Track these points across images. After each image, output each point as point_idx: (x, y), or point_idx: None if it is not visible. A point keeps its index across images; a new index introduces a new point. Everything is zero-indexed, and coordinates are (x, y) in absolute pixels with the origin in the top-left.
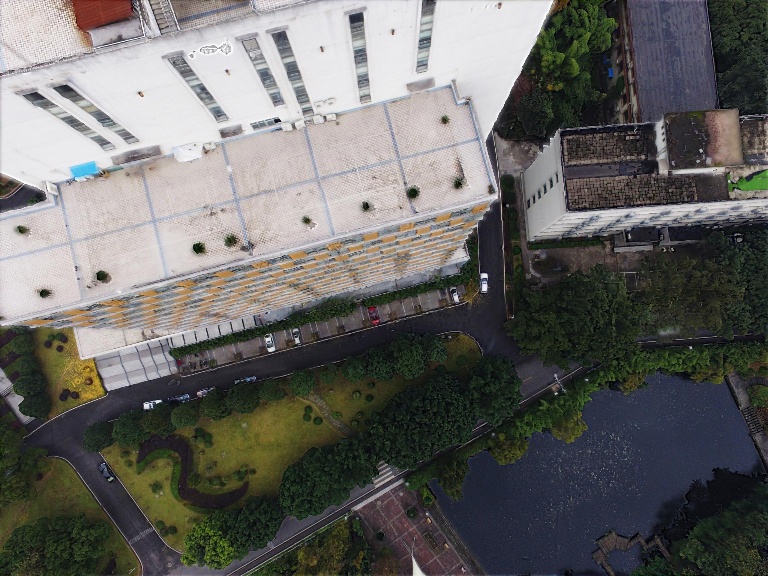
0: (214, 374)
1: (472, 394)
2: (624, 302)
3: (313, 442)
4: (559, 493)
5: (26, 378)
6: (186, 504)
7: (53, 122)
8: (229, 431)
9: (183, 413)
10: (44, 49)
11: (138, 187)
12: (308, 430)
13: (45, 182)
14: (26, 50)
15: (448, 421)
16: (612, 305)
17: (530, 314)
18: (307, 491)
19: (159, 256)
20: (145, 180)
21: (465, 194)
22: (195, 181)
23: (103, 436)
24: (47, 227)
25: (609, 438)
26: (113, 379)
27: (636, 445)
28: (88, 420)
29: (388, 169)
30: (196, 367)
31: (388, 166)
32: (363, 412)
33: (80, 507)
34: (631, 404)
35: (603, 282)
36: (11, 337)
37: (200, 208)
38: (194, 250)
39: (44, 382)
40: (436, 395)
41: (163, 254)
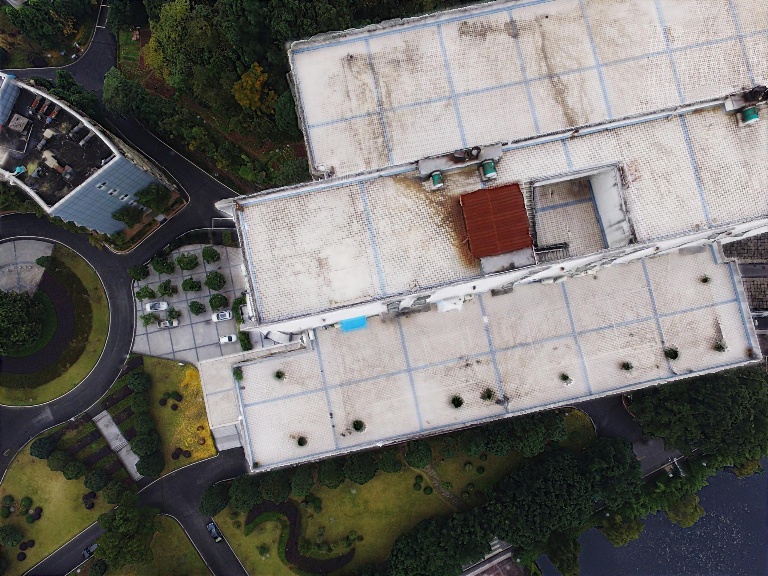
0: None
1: (594, 477)
2: (764, 399)
3: (422, 511)
4: (666, 574)
5: (144, 438)
6: (292, 568)
7: (377, 307)
8: (338, 497)
9: (304, 484)
10: (422, 265)
11: (394, 335)
12: (417, 499)
13: (307, 330)
14: (404, 266)
15: (570, 504)
16: (750, 401)
17: (658, 400)
18: (421, 565)
19: (414, 406)
20: (401, 328)
21: (724, 356)
22: (451, 331)
23: (221, 501)
24: (303, 372)
25: (718, 520)
26: (225, 439)
27: (746, 529)
28: (198, 479)
29: (646, 327)
30: None
31: (646, 324)
32: (473, 484)
33: (187, 566)
34: (742, 487)
35: (742, 377)
36: (127, 393)
37: (456, 359)
38: (454, 404)
39: (159, 441)
40: (558, 476)
41: (418, 404)
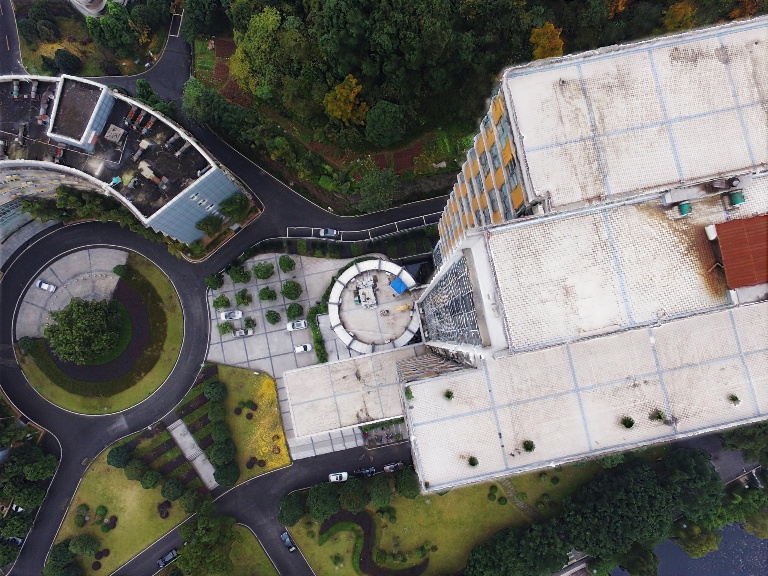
0: (399, 448)
1: (675, 489)
2: None
3: (496, 522)
4: None
5: (222, 447)
6: None
7: None
8: (413, 507)
9: (386, 494)
10: (668, 294)
11: (561, 354)
12: (492, 509)
13: None
14: (650, 294)
15: (652, 516)
16: None
17: None
18: None
19: (583, 426)
20: (568, 348)
21: None
22: (618, 351)
23: (300, 511)
24: (471, 391)
25: None
26: (300, 449)
27: None
28: (272, 488)
29: None
30: (382, 440)
31: None
32: (548, 494)
33: (261, 575)
34: None
35: None
36: (202, 402)
37: (623, 379)
38: (625, 425)
39: (236, 450)
40: (639, 488)
41: (587, 424)
